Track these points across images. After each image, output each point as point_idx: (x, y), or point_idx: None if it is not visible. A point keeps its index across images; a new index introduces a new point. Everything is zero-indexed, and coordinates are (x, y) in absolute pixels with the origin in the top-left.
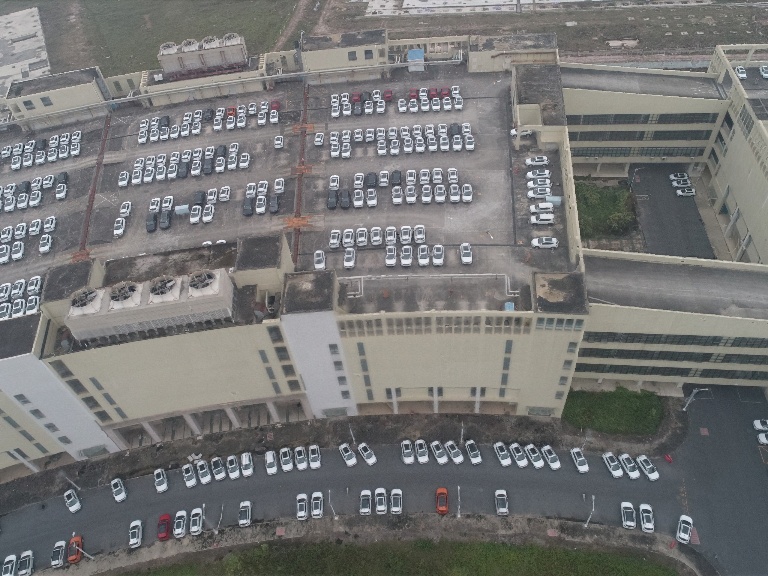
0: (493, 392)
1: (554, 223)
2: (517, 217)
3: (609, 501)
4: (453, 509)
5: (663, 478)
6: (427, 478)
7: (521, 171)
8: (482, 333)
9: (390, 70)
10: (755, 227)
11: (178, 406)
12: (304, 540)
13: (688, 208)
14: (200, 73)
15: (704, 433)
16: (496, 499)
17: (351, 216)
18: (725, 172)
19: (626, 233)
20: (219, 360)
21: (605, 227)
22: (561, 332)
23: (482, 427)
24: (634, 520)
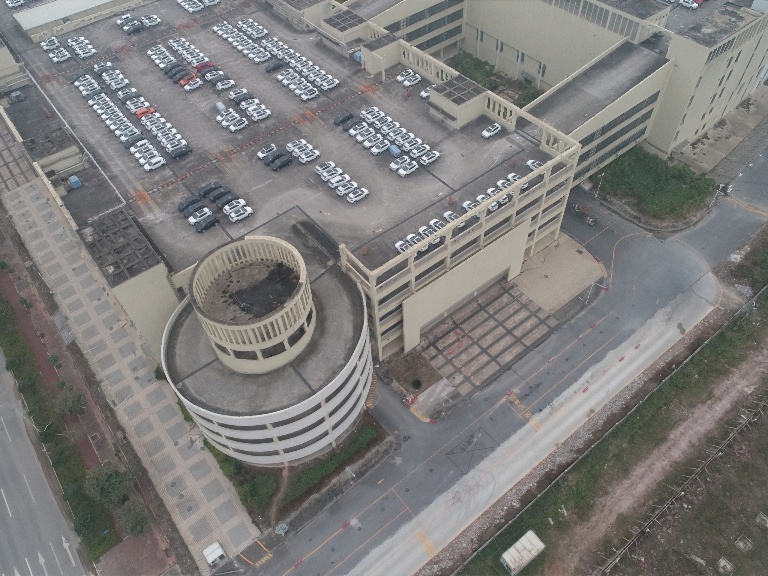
0: None
1: None
2: None
3: None
4: None
5: None
6: None
7: None
8: None
9: None
10: None
11: None
12: None
13: None
14: None
15: None
16: None
17: None
18: None
19: None
20: None
21: None
22: None
23: None
24: None
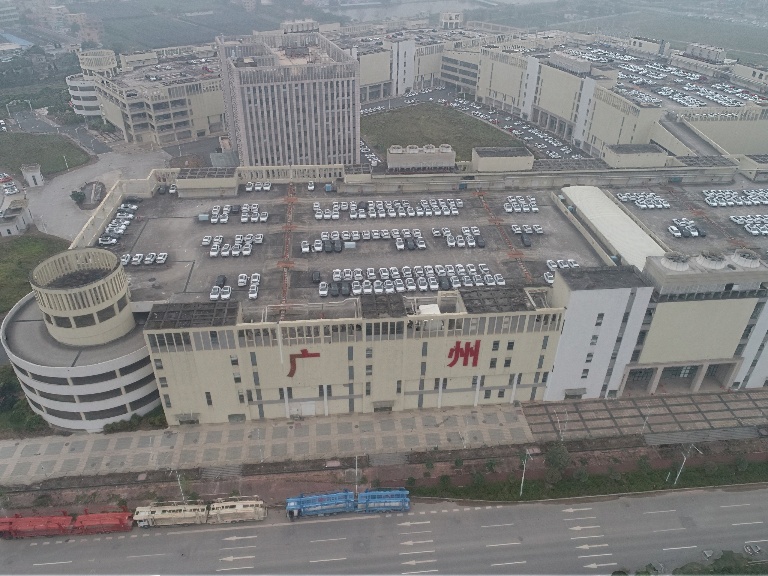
0: None
1: None
2: None
3: None
4: None
5: None
6: None
7: None
8: None
9: (765, 88)
10: None
11: (550, 110)
12: (529, 147)
13: None
14: (696, 58)
15: None
16: None
17: (652, 94)
18: None
19: None
20: (567, 91)
21: None
22: (634, 117)
23: None
24: None
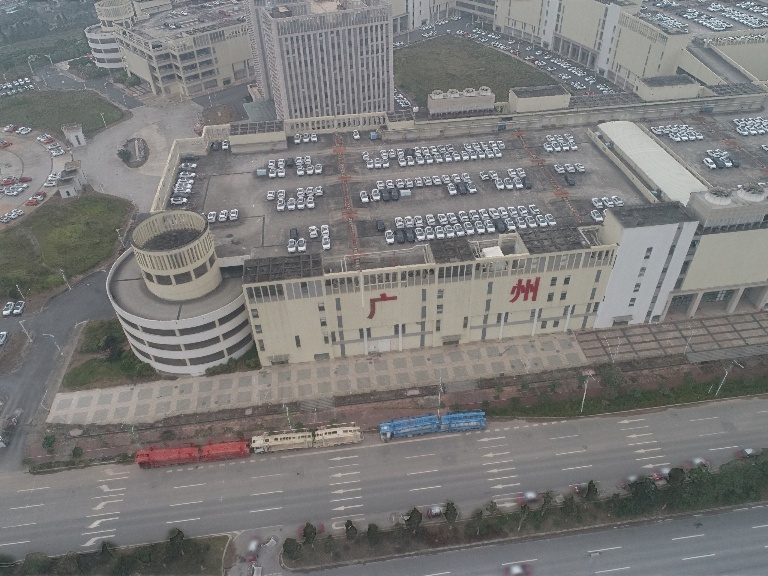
0: None
1: None
2: None
3: None
4: None
5: None
6: None
7: None
8: None
9: None
10: None
11: (572, 38)
12: None
13: None
14: None
15: None
16: None
17: (677, 17)
18: None
19: None
20: (590, 18)
21: None
22: None
23: None
24: None
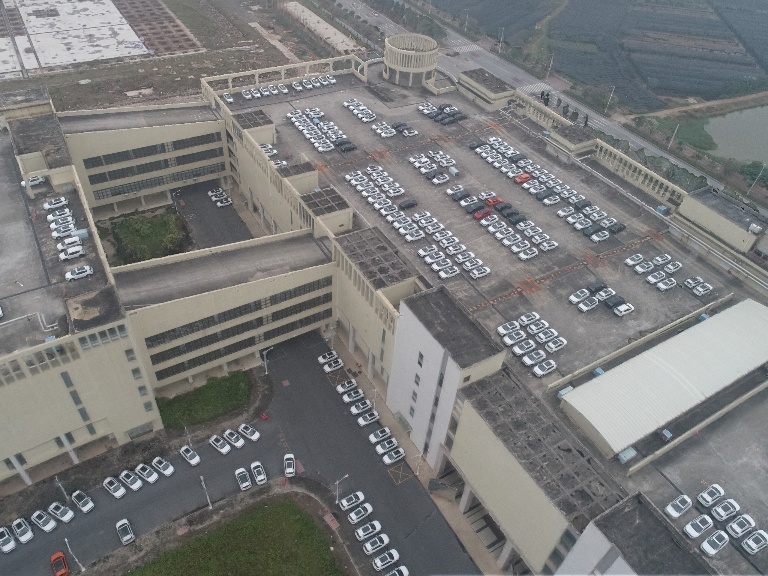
0: (82, 434)
1: (85, 254)
2: (46, 259)
3: (225, 476)
4: (75, 567)
5: (264, 435)
6: (37, 553)
7: (41, 217)
8: (29, 376)
9: None
10: (273, 213)
11: None
12: None
13: (230, 215)
14: None
15: (286, 384)
16: (118, 532)
17: None
18: (243, 178)
19: (183, 250)
20: None
21: (162, 250)
22: (110, 344)
23: (87, 474)
24: (248, 480)
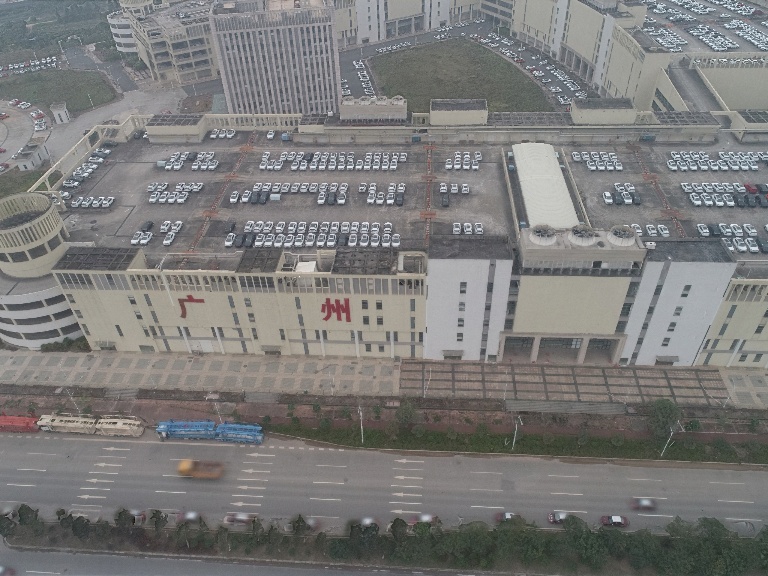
0: None
1: None
2: None
3: None
4: None
5: None
6: None
7: None
8: None
9: None
10: None
11: (576, 49)
12: (543, 91)
13: None
14: None
15: None
16: None
17: (683, 33)
18: None
19: None
20: None
21: None
22: None
23: None
24: None
